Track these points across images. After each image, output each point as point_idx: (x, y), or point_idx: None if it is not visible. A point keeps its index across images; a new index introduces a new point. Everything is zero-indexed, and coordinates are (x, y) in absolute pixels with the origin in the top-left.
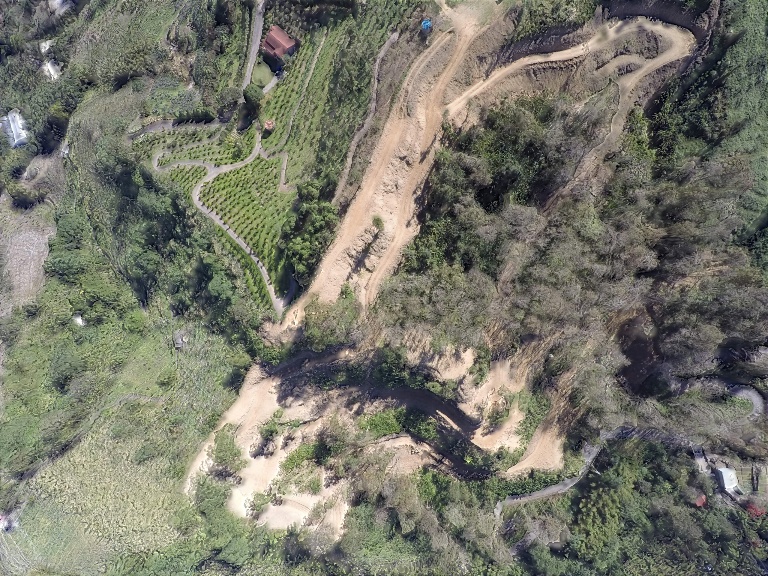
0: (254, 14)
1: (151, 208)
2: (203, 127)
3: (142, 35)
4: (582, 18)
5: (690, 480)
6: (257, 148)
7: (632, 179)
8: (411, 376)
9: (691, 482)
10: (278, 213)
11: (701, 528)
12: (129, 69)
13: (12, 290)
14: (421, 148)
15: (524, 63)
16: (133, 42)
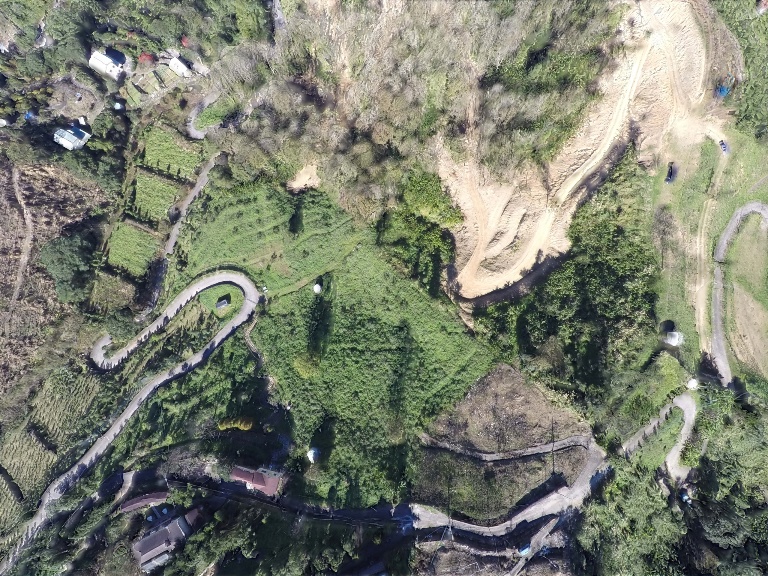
0: None
1: None
2: None
3: None
4: (581, 215)
5: (200, 50)
6: None
7: (421, 177)
8: None
9: (199, 49)
10: None
11: (175, 13)
12: None
13: None
14: (646, 0)
15: (602, 147)
16: None
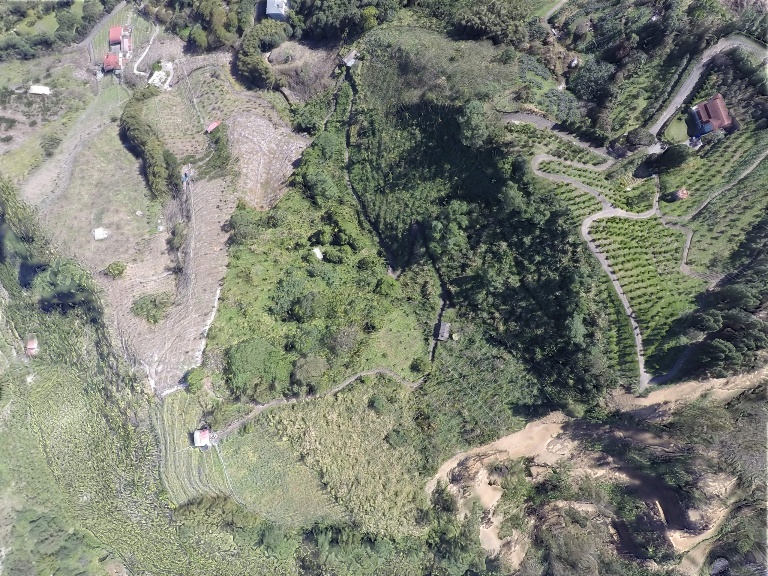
0: (693, 65)
1: (512, 208)
2: (588, 149)
3: (526, 4)
4: None
5: None
6: (655, 207)
7: None
8: (694, 480)
9: None
10: (680, 293)
11: None
12: (494, 30)
13: (240, 183)
14: None
15: None
16: (512, 5)
